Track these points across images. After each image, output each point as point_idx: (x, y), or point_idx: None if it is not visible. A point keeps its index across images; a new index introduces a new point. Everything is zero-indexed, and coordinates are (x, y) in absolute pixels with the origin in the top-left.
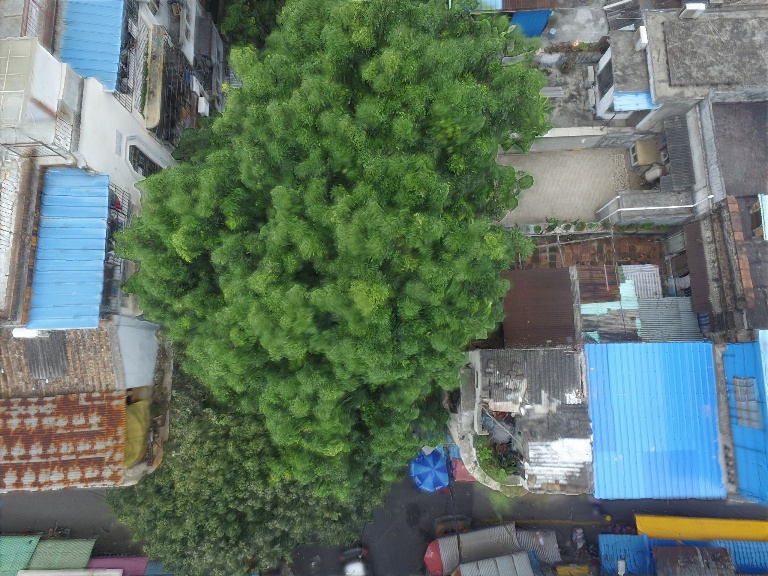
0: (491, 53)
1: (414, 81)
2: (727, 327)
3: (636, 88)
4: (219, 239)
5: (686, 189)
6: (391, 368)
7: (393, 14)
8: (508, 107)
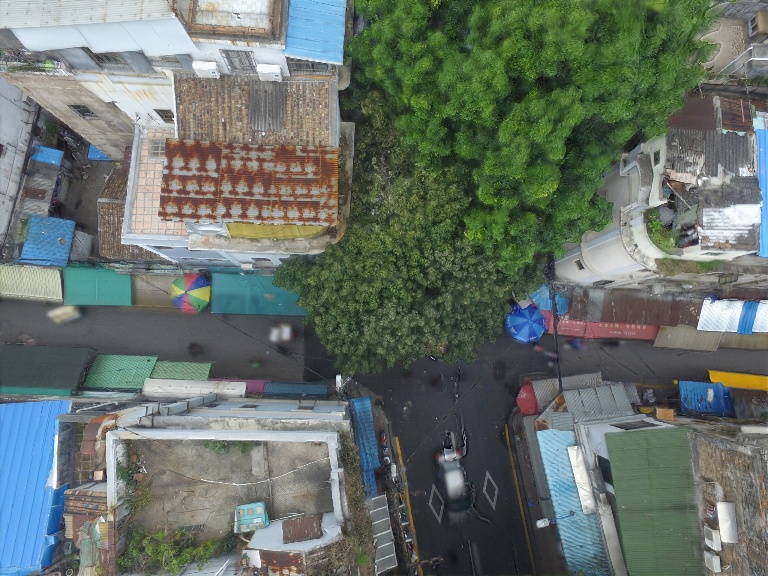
0: None
1: None
2: None
3: None
4: None
5: None
6: None
7: None
8: None
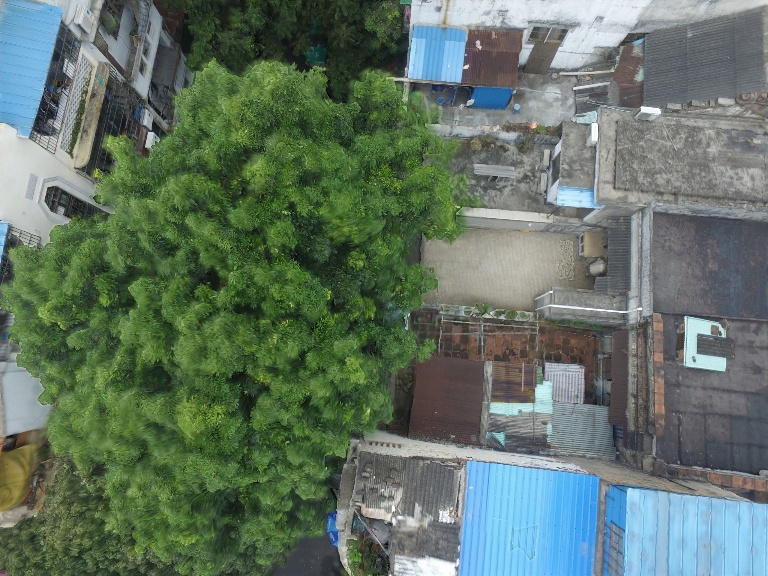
0: (407, 150)
1: (302, 184)
2: (637, 448)
3: (581, 185)
4: (93, 313)
5: (621, 294)
6: (244, 473)
7: (290, 112)
8: (419, 206)
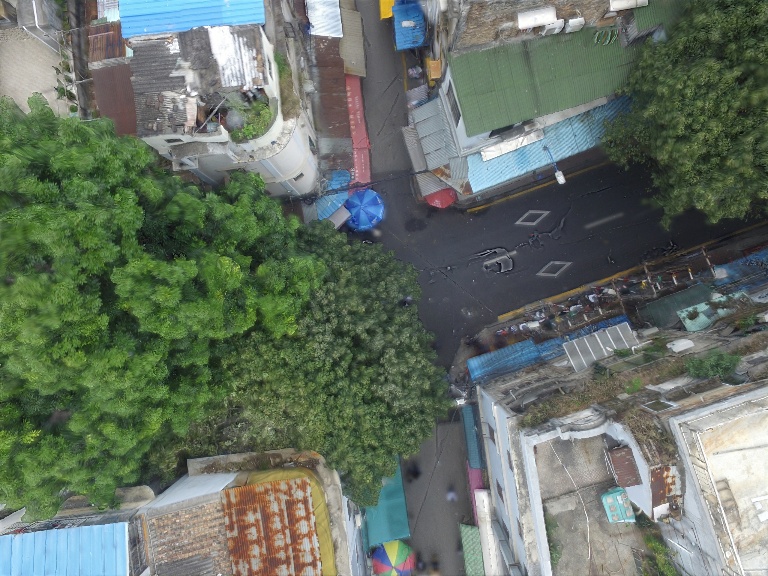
0: None
1: None
2: None
3: None
4: None
5: None
6: None
7: None
8: None
